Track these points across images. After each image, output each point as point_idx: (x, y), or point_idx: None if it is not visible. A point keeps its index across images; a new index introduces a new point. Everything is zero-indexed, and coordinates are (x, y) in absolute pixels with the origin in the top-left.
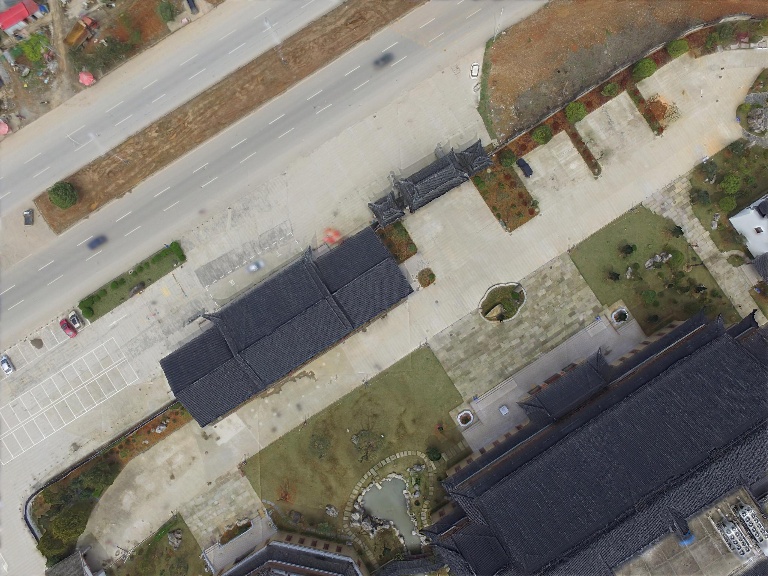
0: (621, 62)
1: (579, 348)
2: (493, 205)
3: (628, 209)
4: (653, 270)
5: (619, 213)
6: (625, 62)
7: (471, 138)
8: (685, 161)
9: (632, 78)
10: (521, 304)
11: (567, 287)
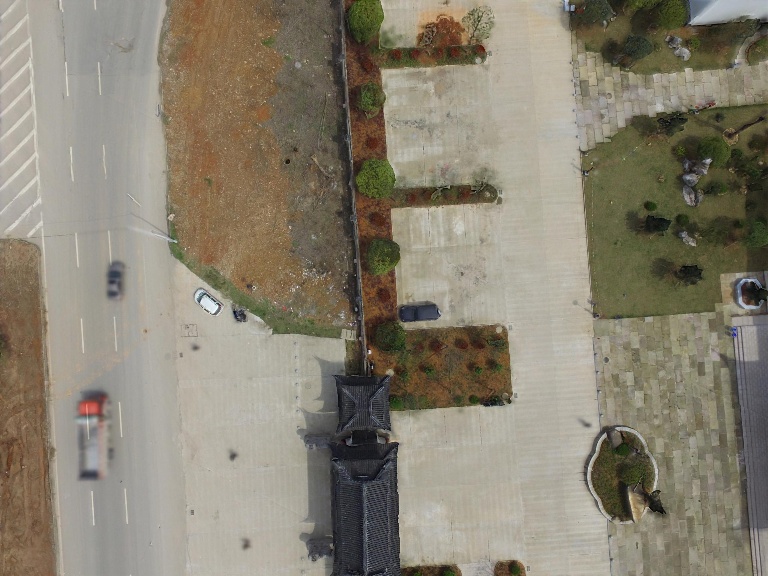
0: (329, 50)
1: (766, 391)
2: (451, 399)
3: (579, 178)
4: (704, 197)
5: (578, 197)
6: (332, 43)
7: (318, 371)
8: (551, 40)
9: (367, 48)
10: (642, 446)
11: (653, 352)
